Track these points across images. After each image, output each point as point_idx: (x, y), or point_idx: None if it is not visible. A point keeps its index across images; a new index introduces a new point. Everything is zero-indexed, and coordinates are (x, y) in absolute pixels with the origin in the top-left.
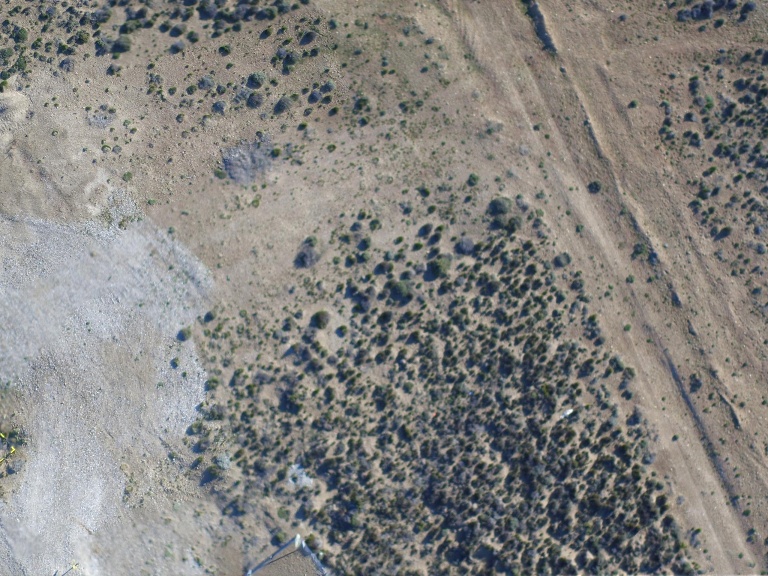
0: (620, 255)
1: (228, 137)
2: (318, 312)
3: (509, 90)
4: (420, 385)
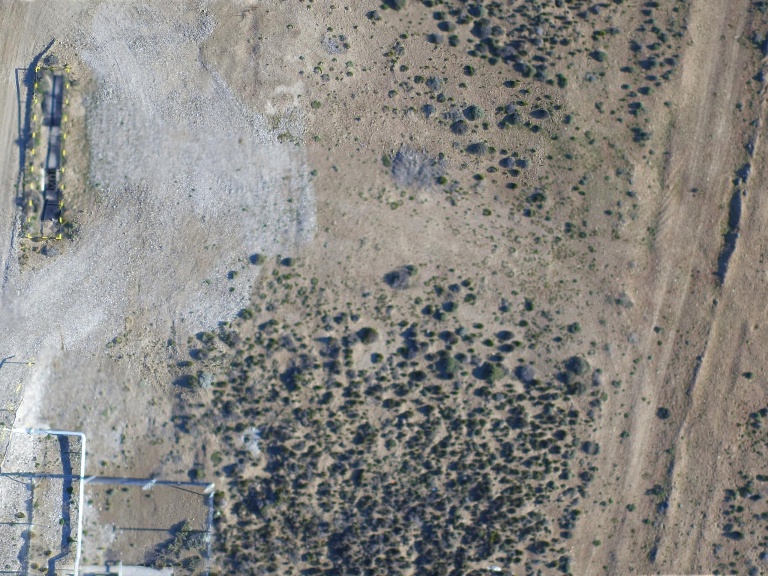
0: (639, 482)
1: (416, 138)
2: (372, 328)
3: (660, 282)
4: (401, 450)
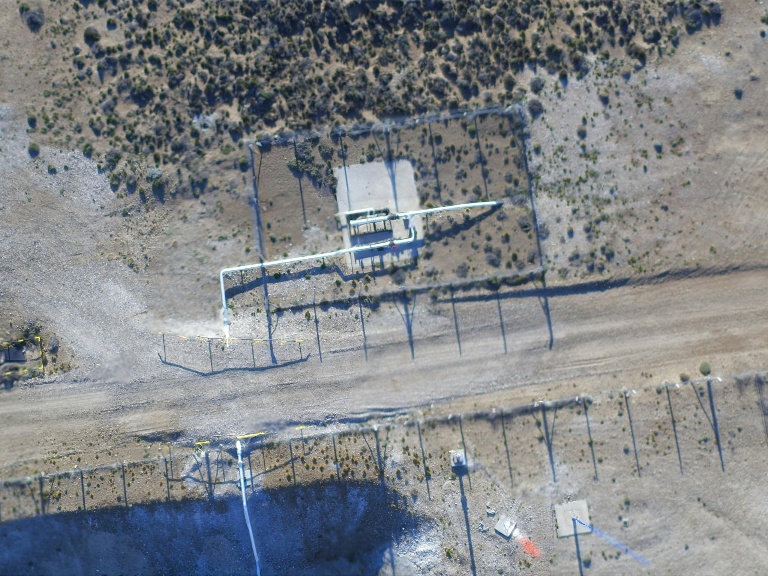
0: None
1: None
2: (84, 34)
3: None
4: None
